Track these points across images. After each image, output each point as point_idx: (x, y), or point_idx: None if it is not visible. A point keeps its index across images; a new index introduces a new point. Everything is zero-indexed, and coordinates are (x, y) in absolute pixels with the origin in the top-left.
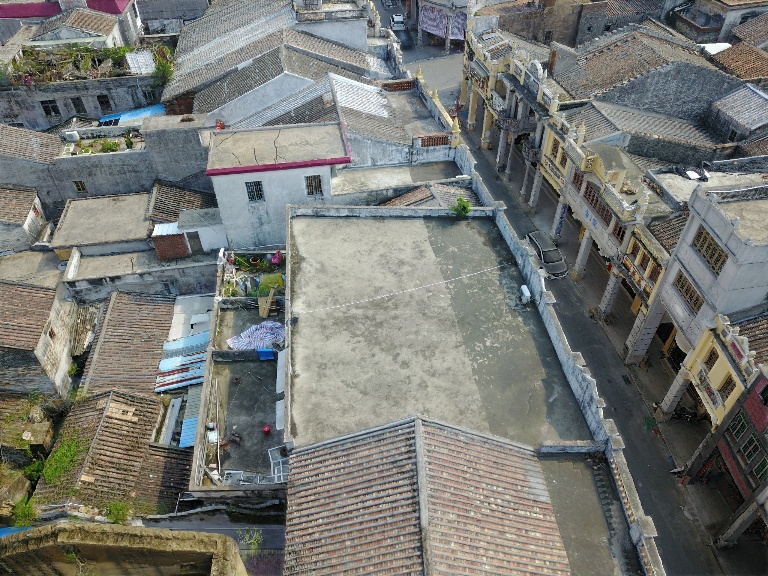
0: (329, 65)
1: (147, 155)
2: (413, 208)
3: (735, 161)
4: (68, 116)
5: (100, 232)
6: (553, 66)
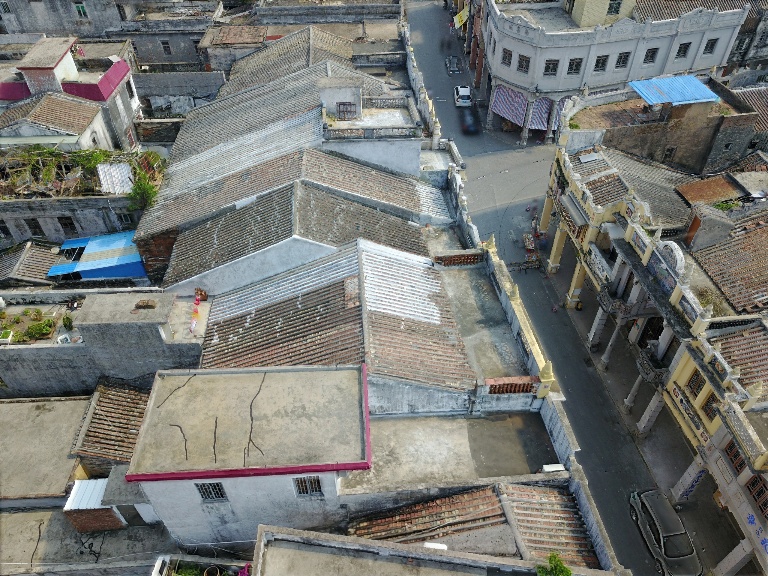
0: (363, 207)
1: (86, 350)
2: (470, 558)
3: None
4: (22, 238)
5: (1, 475)
6: (693, 238)
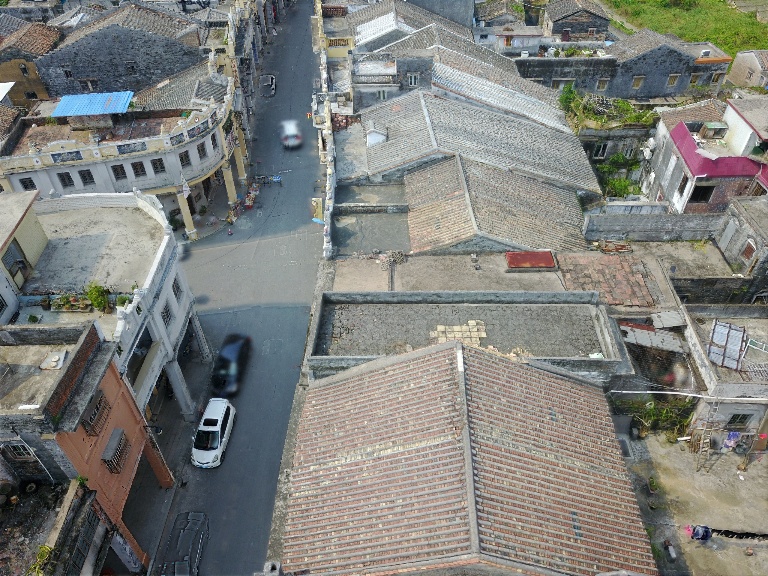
0: None
1: None
2: None
3: (161, 3)
4: None
5: None
6: None
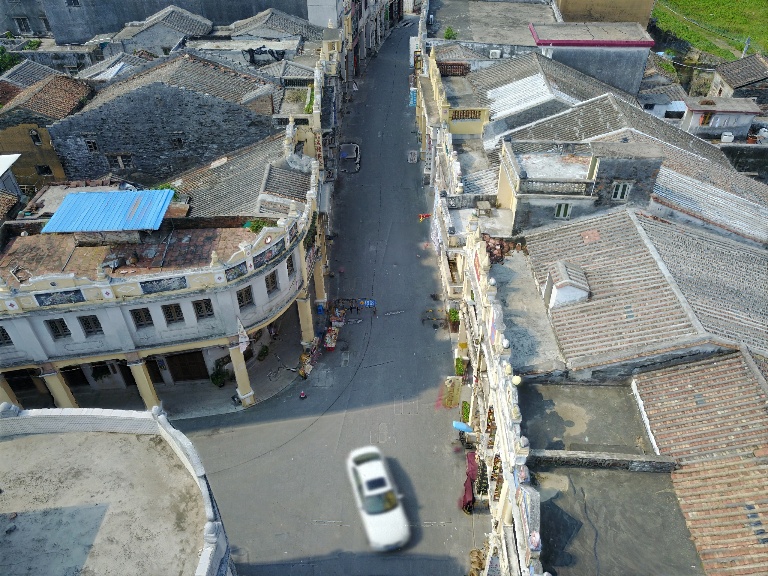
0: None
1: None
2: None
3: None
4: None
5: None
6: None
